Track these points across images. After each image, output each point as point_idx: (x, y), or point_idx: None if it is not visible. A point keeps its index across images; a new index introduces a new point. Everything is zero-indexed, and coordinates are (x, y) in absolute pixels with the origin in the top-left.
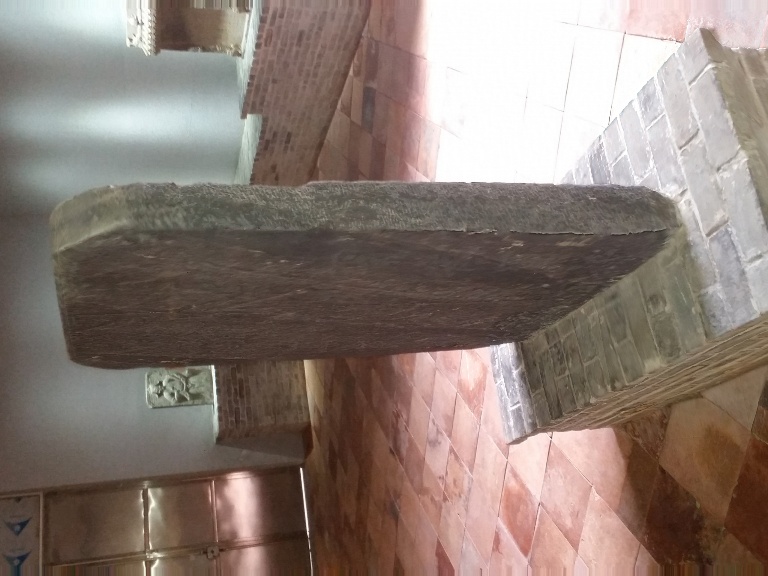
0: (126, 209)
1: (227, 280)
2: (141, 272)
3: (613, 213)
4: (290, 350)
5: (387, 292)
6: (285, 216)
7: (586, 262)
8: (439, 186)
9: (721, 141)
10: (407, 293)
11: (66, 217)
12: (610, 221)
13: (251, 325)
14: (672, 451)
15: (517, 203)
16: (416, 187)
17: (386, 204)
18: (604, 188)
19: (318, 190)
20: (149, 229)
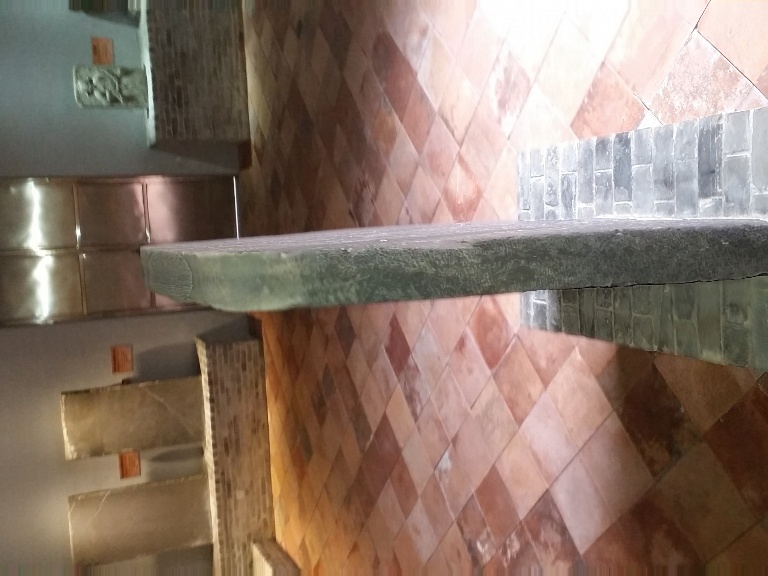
0: (300, 285)
1: None
2: None
3: (739, 258)
4: None
5: None
6: (452, 283)
7: None
8: (594, 238)
9: None
10: None
11: (226, 274)
12: (735, 266)
13: None
14: (671, 359)
15: (660, 253)
16: (573, 240)
17: (544, 262)
18: (737, 230)
19: (484, 251)
20: (321, 304)
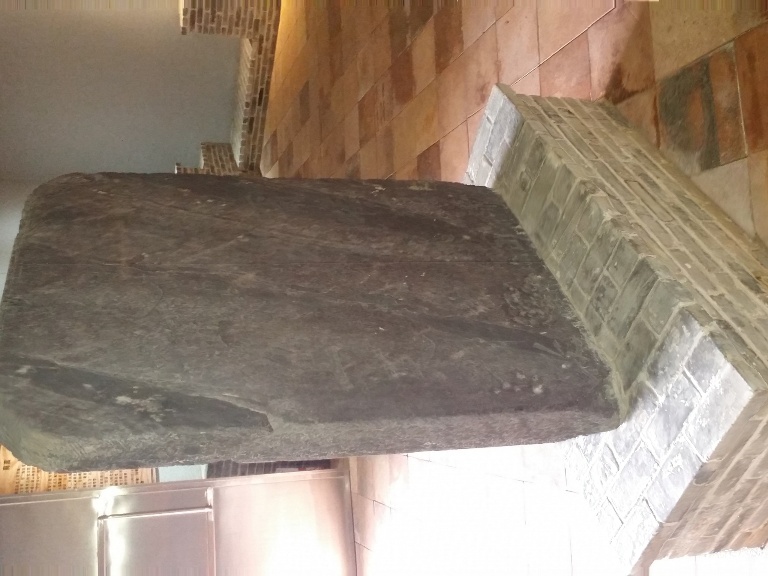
0: None
1: (170, 222)
2: (95, 209)
3: None
4: (296, 376)
5: (326, 244)
6: None
7: (461, 209)
8: None
9: None
10: (347, 246)
11: None
12: None
13: (217, 299)
14: None
15: None
16: None
17: None
18: None
19: None
20: None
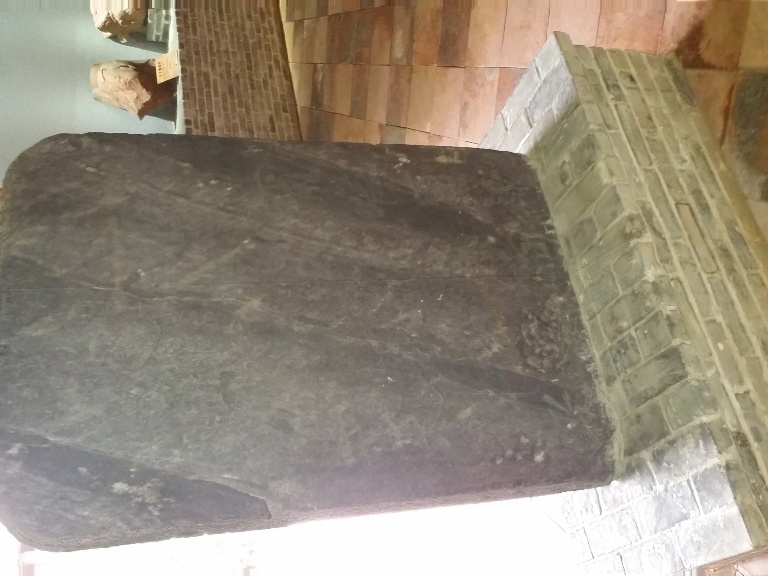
0: None
1: (168, 217)
2: (83, 197)
3: None
4: (298, 448)
5: (340, 251)
6: None
7: (490, 193)
8: None
9: (497, 131)
10: (362, 254)
11: None
12: None
13: (218, 338)
14: None
15: None
16: None
17: None
18: None
19: None
20: None
